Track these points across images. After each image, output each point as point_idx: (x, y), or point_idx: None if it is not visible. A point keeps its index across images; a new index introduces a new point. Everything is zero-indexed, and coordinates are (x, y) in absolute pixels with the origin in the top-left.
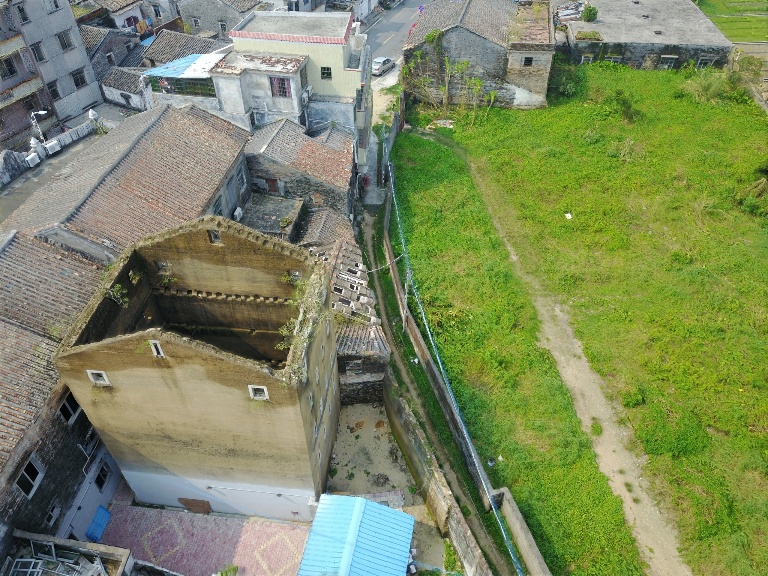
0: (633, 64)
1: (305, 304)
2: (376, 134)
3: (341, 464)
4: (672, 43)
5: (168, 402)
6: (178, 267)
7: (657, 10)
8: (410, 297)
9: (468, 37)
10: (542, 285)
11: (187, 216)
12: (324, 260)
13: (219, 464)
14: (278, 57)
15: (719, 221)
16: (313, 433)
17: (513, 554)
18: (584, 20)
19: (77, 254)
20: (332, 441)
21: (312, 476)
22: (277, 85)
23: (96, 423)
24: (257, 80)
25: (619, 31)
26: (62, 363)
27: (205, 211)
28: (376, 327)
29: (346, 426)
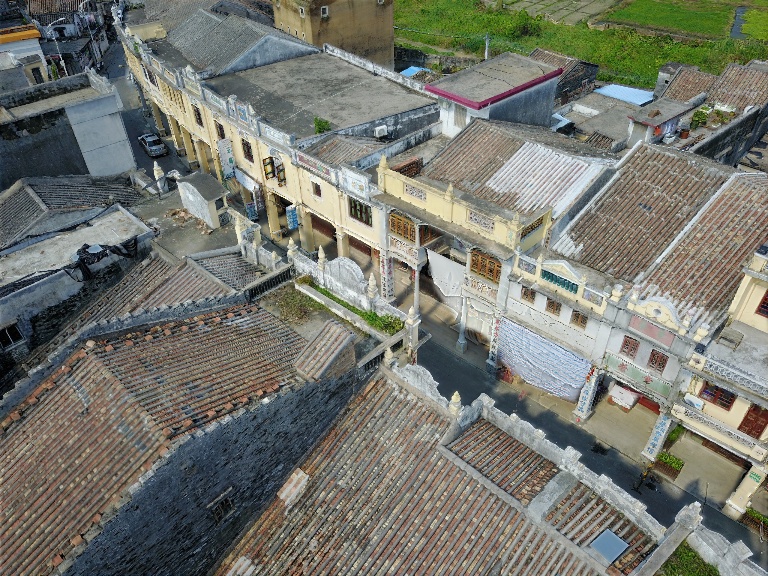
0: None
1: None
2: None
3: None
4: None
5: (348, 20)
6: None
7: None
8: None
9: None
10: None
11: None
12: None
13: None
14: None
15: (423, 2)
16: None
17: None
18: None
19: None
20: None
21: None
22: None
23: None
24: None
25: None
26: (312, 5)
27: None
28: None
29: None
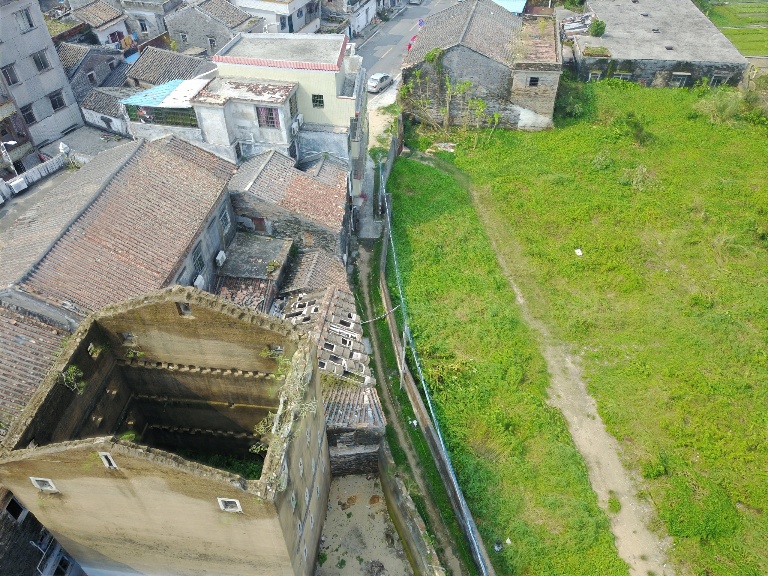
0: (643, 81)
1: (286, 392)
2: (373, 158)
3: (331, 549)
4: (684, 60)
5: (127, 510)
6: (145, 339)
7: (667, 23)
8: (408, 348)
9: (470, 56)
10: (551, 332)
11: (161, 268)
12: (314, 310)
13: (190, 566)
14: (266, 84)
15: (740, 258)
16: (296, 534)
17: None
18: (591, 34)
19: (34, 318)
20: (321, 523)
21: None
22: (264, 115)
23: (47, 525)
24: (243, 110)
25: (628, 46)
26: (1, 470)
27: (182, 261)
28: (370, 390)
29: (337, 502)
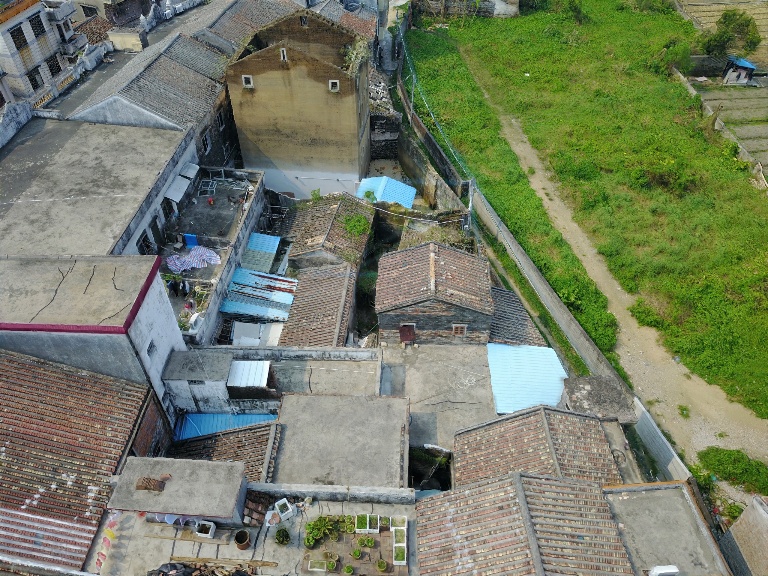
0: None
1: (357, 51)
2: (390, 32)
3: None
4: None
5: (283, 99)
6: None
7: None
8: (415, 110)
9: None
10: (505, 109)
11: None
12: None
13: (305, 154)
14: None
15: (633, 78)
16: (359, 132)
17: (474, 215)
18: None
19: (215, 49)
20: (366, 170)
21: (358, 160)
22: None
23: (238, 123)
24: None
25: None
26: (230, 71)
27: None
28: (393, 111)
29: (374, 169)
